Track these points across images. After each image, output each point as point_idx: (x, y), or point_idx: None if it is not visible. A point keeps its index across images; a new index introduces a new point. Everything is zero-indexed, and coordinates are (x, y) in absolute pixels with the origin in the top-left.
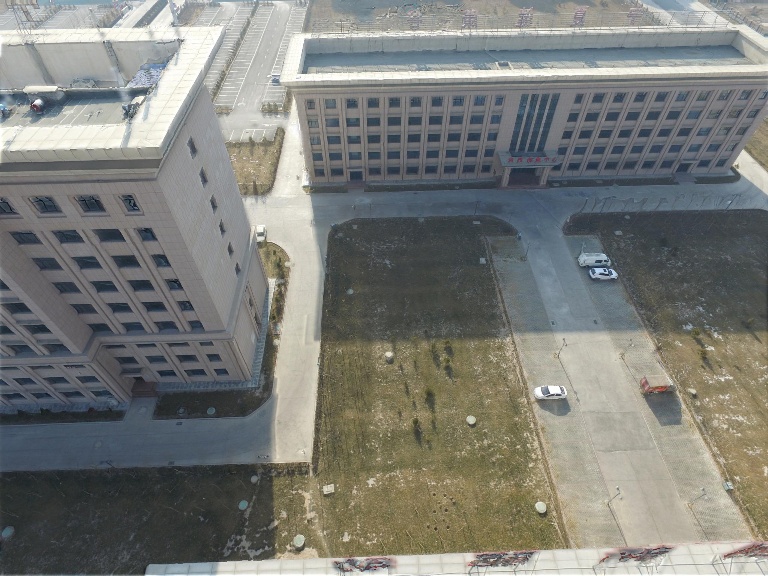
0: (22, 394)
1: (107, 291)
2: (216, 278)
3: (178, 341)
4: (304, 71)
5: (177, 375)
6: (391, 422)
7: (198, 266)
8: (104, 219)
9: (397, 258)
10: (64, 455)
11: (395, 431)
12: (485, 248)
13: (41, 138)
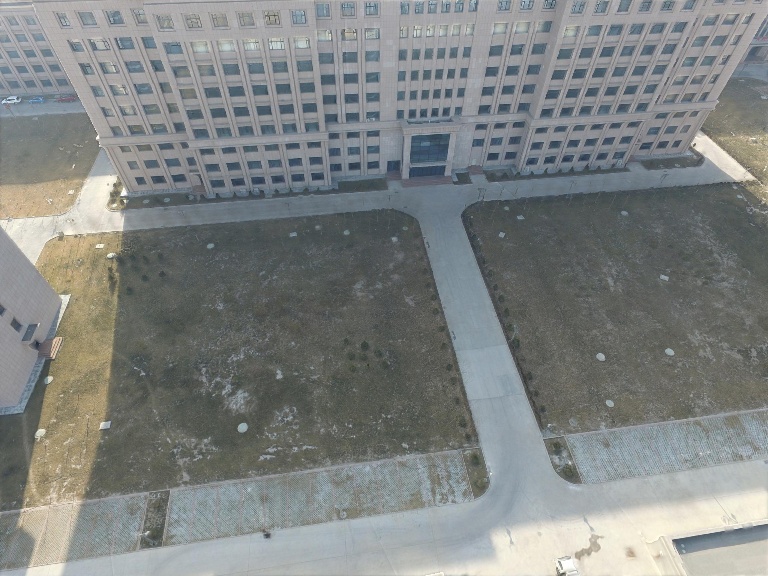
0: (575, 156)
1: (685, 66)
2: None
3: (686, 110)
4: None
5: (651, 147)
6: None
7: None
8: (740, 6)
9: None
10: (615, 186)
11: None
12: (759, 92)
13: None
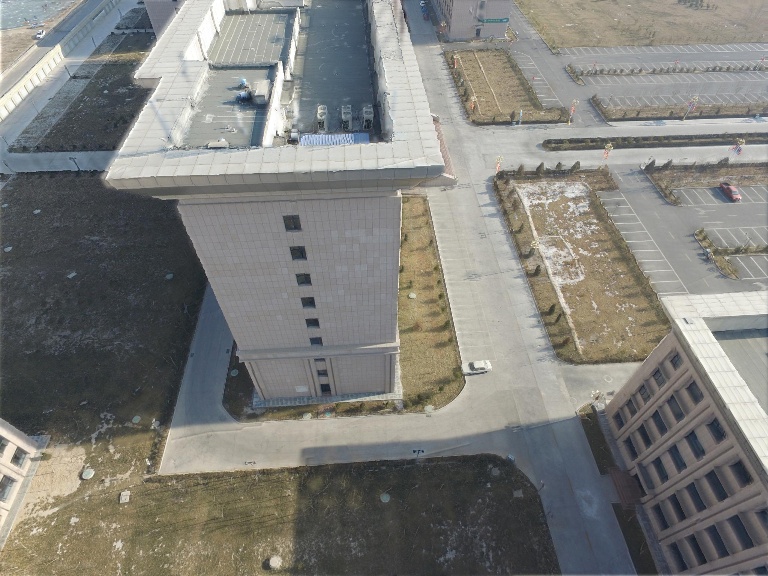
0: None
1: None
2: (253, 317)
3: None
4: (765, 332)
5: None
6: (181, 568)
7: (218, 291)
8: None
9: (461, 572)
10: None
11: (168, 574)
12: None
13: (162, 112)
